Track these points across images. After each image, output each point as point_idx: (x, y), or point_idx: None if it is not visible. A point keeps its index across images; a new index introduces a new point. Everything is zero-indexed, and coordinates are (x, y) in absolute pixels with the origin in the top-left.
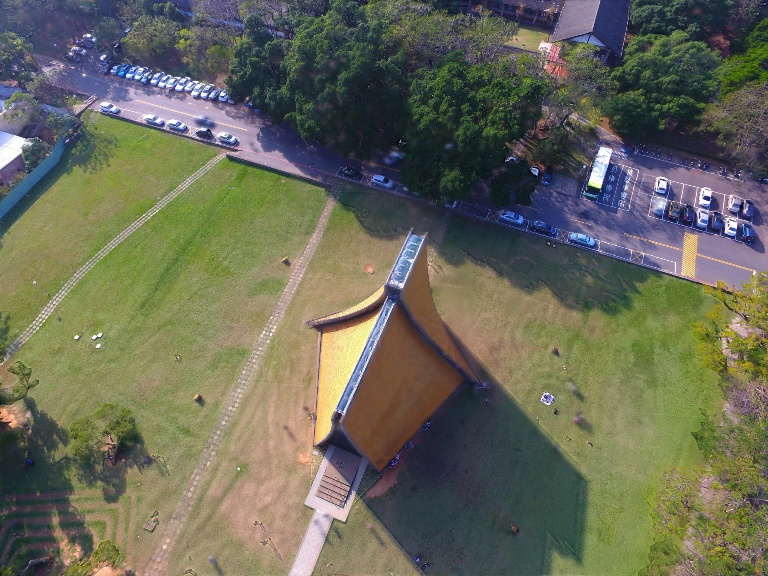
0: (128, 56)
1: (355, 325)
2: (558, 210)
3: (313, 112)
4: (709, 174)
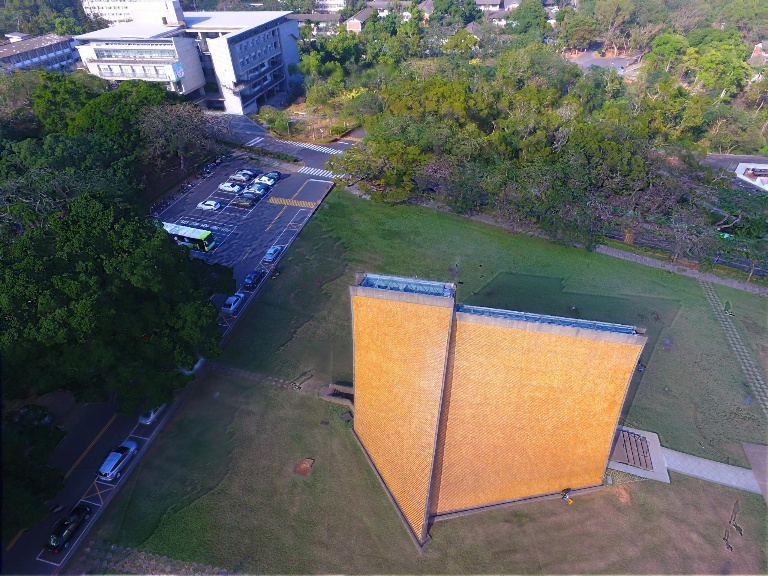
0: None
1: (447, 421)
2: None
3: None
4: (201, 184)
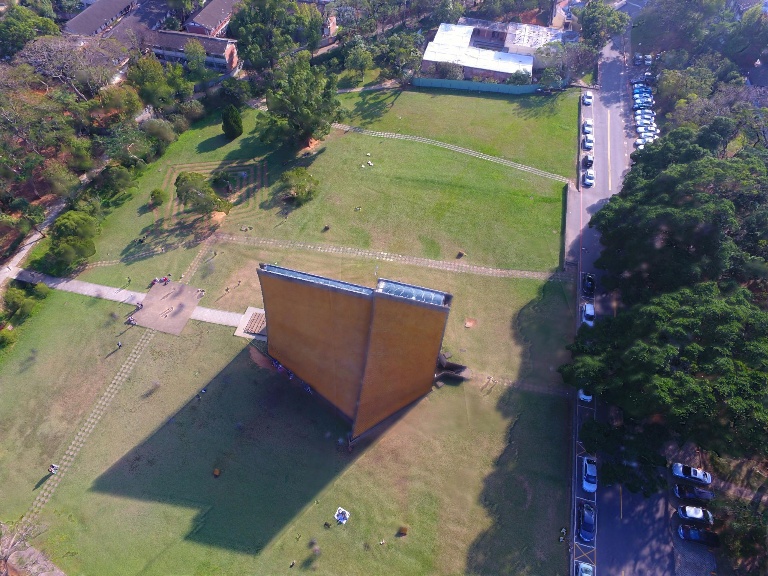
0: (655, 84)
1: None
2: (634, 551)
3: (624, 211)
4: None
